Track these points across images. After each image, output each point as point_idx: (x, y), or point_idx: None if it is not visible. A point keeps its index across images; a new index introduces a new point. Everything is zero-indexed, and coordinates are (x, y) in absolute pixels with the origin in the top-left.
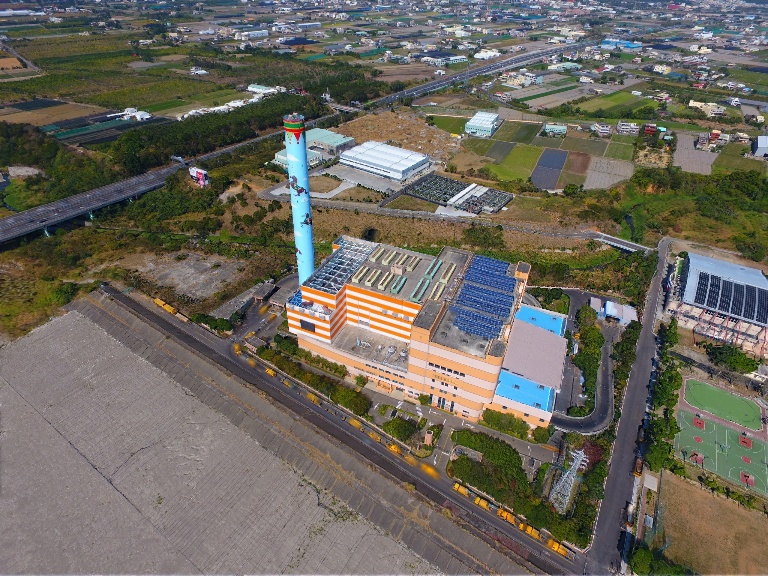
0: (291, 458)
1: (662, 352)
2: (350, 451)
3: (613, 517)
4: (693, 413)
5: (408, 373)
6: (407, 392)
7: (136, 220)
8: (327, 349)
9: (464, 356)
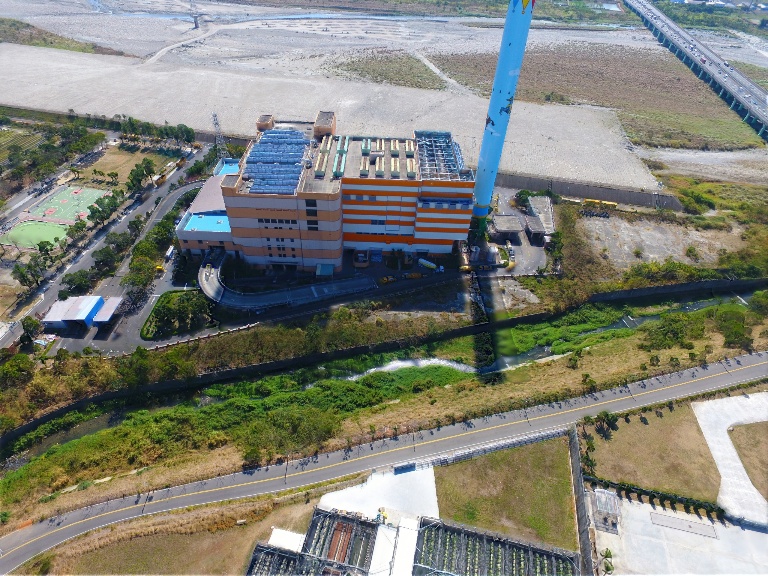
0: None
1: None
2: None
3: (192, 164)
4: None
5: None
6: None
7: None
8: None
9: None
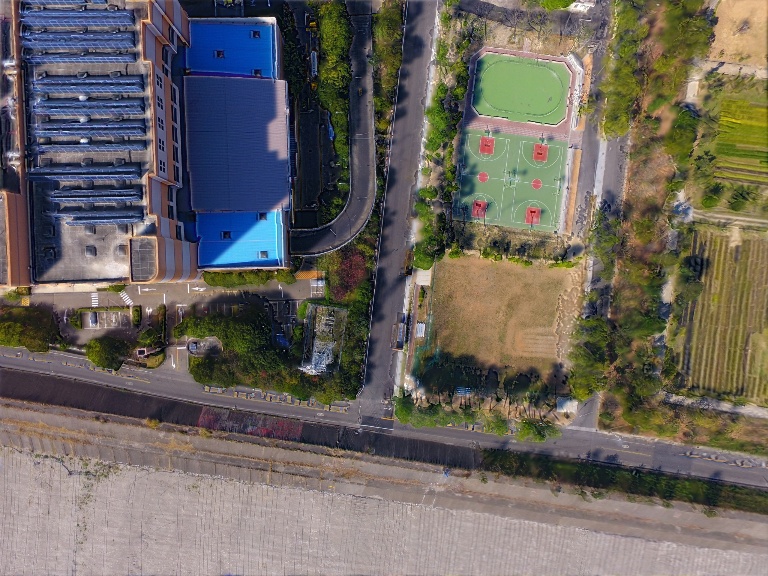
0: (3, 441)
1: (443, 18)
2: (62, 411)
3: (384, 341)
4: (481, 130)
5: None
6: None
7: None
8: None
9: None
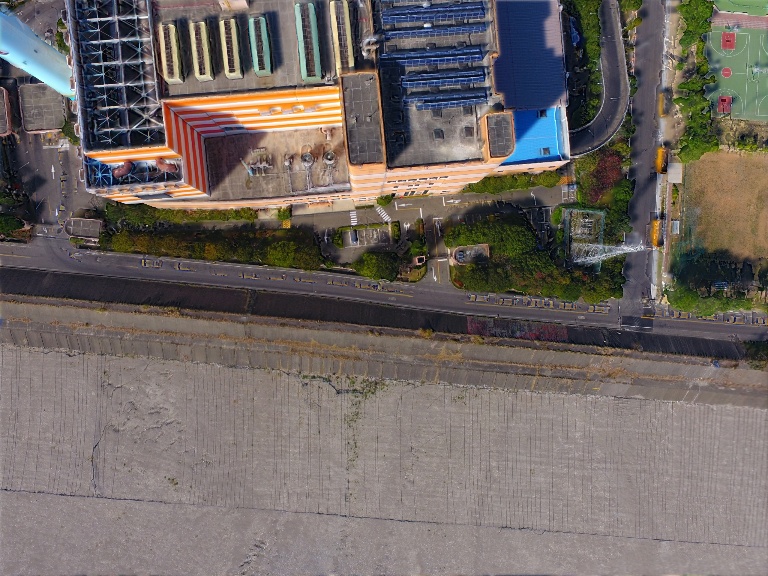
0: (272, 363)
1: None
2: (337, 327)
3: (639, 241)
4: (722, 26)
5: (354, 192)
6: (357, 200)
7: None
8: (209, 204)
9: (449, 168)
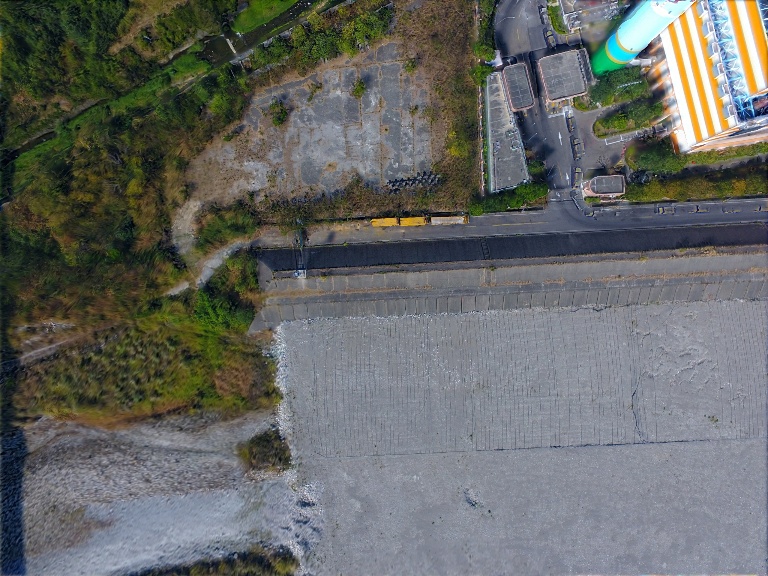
0: None
1: None
2: None
3: None
4: None
5: None
6: None
7: (62, 90)
8: (764, 137)
9: None
